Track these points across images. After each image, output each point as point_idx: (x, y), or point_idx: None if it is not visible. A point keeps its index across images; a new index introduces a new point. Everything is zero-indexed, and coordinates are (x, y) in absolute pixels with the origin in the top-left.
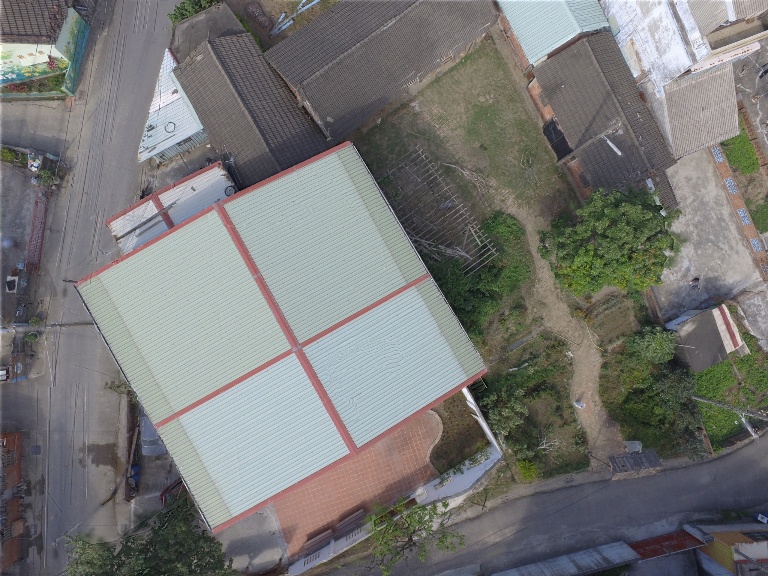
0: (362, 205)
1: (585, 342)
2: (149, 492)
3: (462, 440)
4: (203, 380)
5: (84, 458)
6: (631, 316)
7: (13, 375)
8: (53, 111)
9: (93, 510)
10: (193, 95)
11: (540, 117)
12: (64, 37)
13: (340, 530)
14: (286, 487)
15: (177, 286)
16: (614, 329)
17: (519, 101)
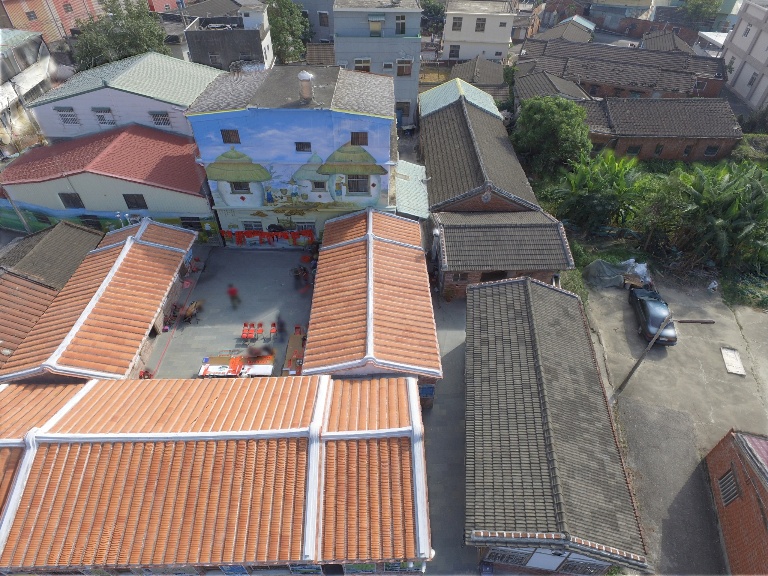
0: None
1: None
2: None
3: None
4: None
5: None
6: None
7: None
8: None
9: None
10: None
11: None
12: None
13: None
14: None
15: None
16: None
17: None
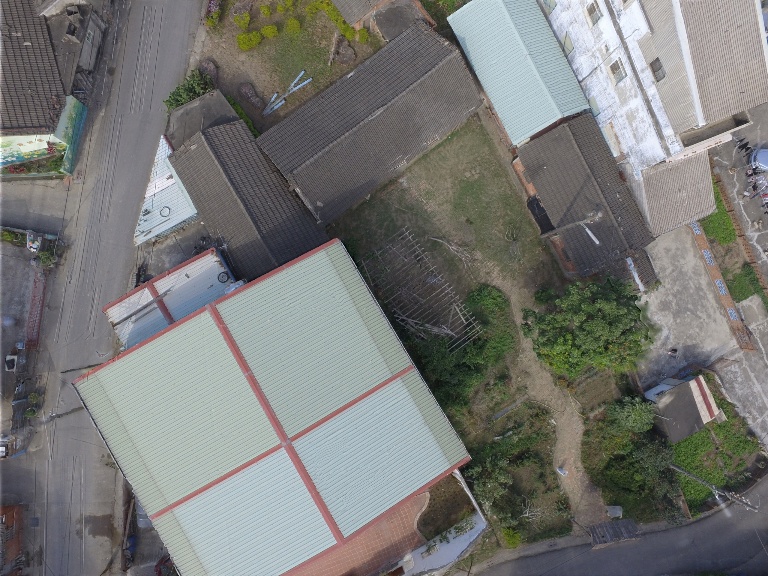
0: (349, 300)
1: (568, 410)
2: (144, 562)
3: (448, 507)
4: (196, 473)
5: (81, 529)
6: (612, 384)
7: (12, 452)
8: (51, 190)
9: None
10: (187, 181)
11: (524, 191)
12: (62, 124)
13: None
14: (276, 575)
15: (171, 383)
16: (596, 397)
17: (504, 176)
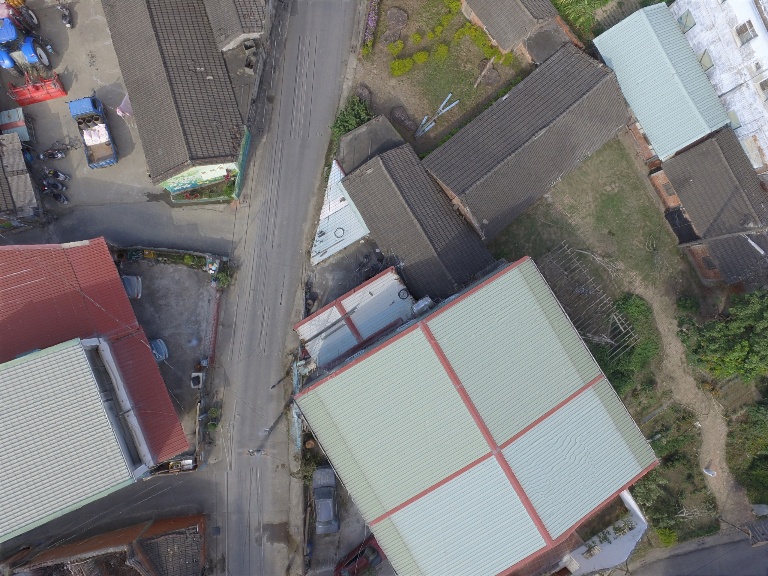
0: (542, 314)
1: (711, 412)
2: (320, 567)
3: (602, 509)
4: (412, 482)
5: (260, 537)
6: (752, 386)
7: (200, 464)
8: (220, 214)
9: None
10: (361, 203)
11: (661, 202)
12: None
13: None
14: None
15: (386, 397)
16: (737, 399)
17: (642, 188)
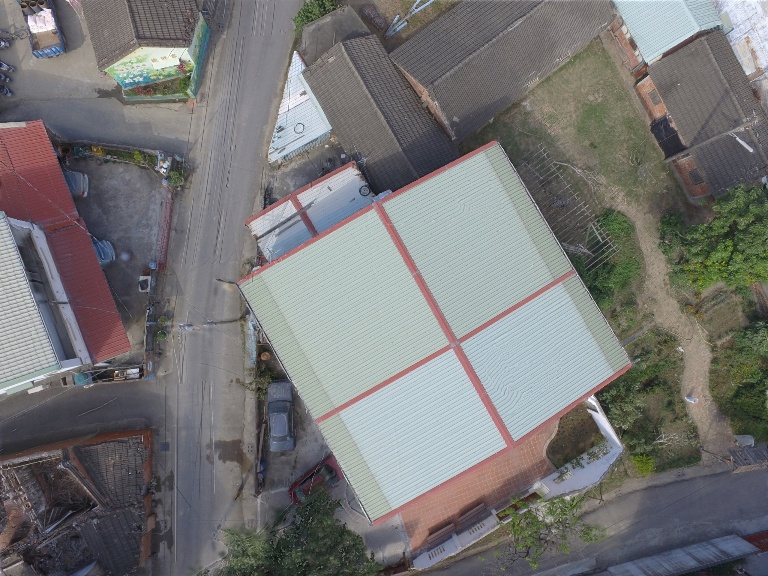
0: (510, 203)
1: (695, 337)
2: (275, 487)
3: (577, 435)
4: (363, 376)
5: (211, 454)
6: (739, 311)
7: (147, 373)
8: (175, 113)
9: (221, 505)
10: (322, 96)
11: (647, 115)
12: (193, 40)
13: (462, 524)
14: (445, 480)
15: (337, 284)
16: (723, 324)
17: (627, 99)
